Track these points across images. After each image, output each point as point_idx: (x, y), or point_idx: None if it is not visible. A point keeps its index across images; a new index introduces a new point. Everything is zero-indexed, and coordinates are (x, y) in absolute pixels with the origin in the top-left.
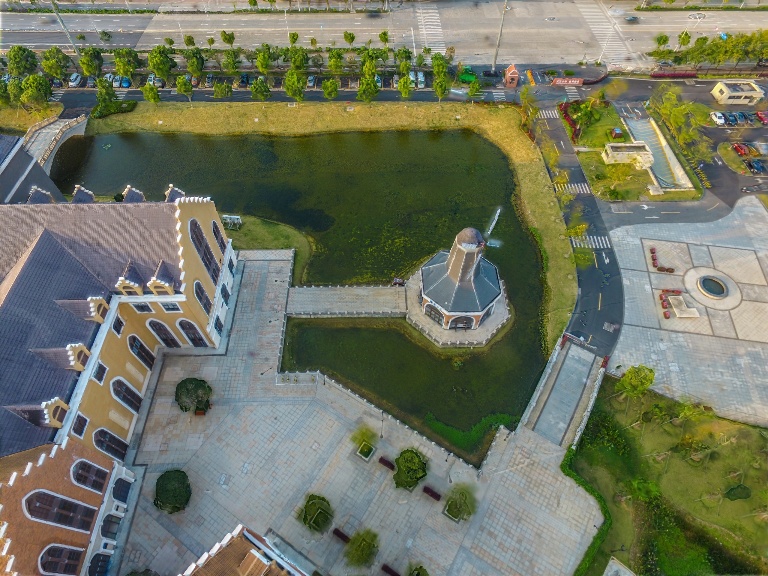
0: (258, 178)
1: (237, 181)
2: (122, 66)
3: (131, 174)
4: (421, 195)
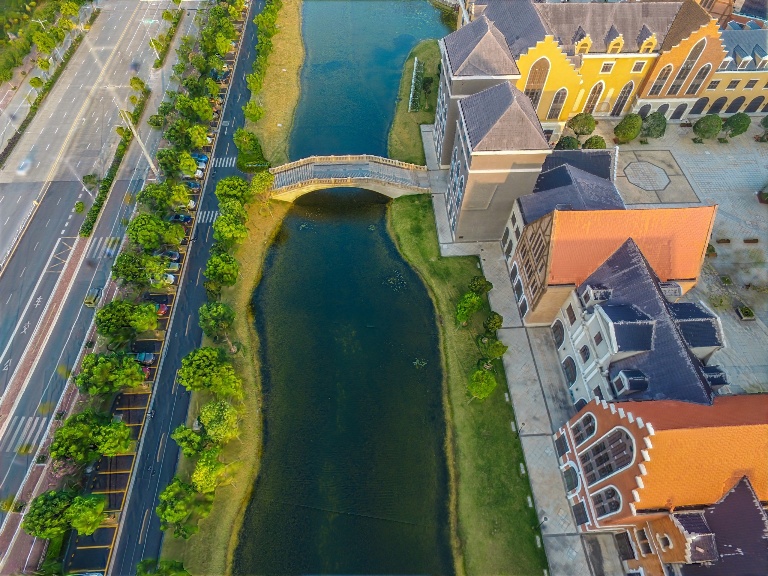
0: (360, 67)
1: (364, 76)
2: (202, 130)
3: (356, 134)
4: (376, 5)
